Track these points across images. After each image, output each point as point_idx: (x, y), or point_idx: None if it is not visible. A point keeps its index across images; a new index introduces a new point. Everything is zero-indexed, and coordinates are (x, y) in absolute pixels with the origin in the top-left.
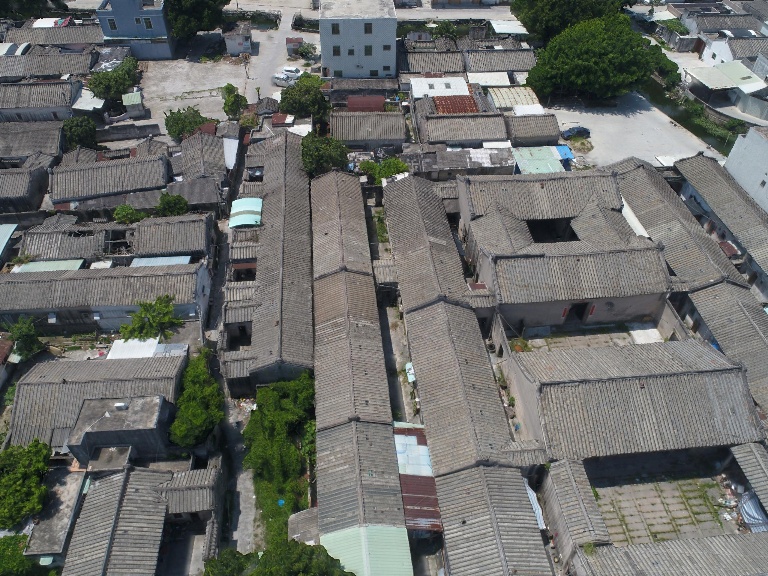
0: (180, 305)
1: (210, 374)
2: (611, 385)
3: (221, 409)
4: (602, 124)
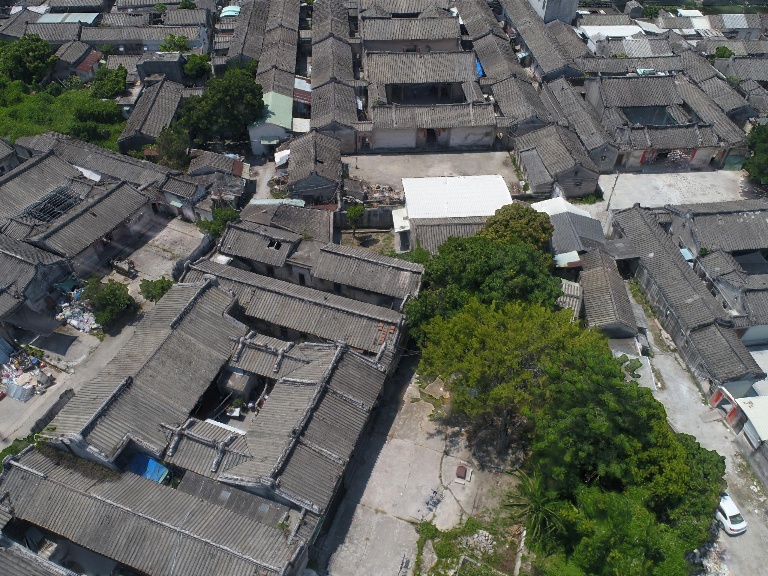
0: (191, 43)
1: None
2: (405, 56)
3: None
4: None
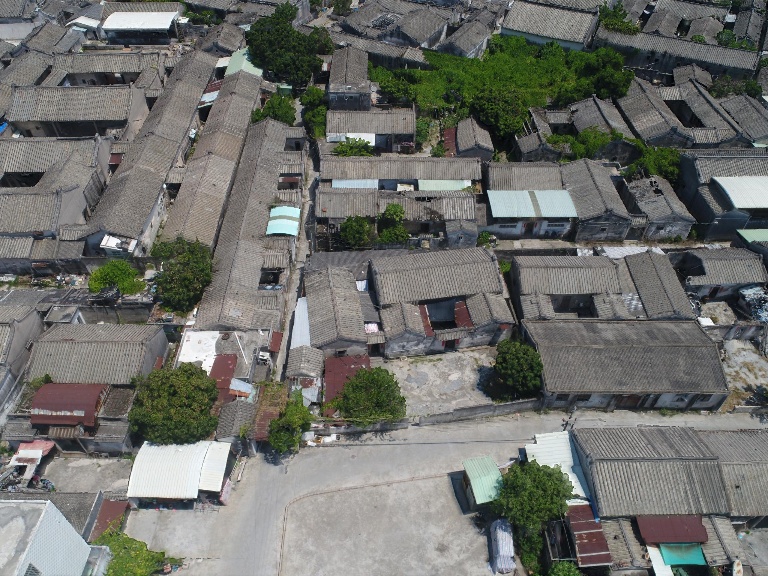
0: None
1: None
2: None
3: (311, 143)
4: None
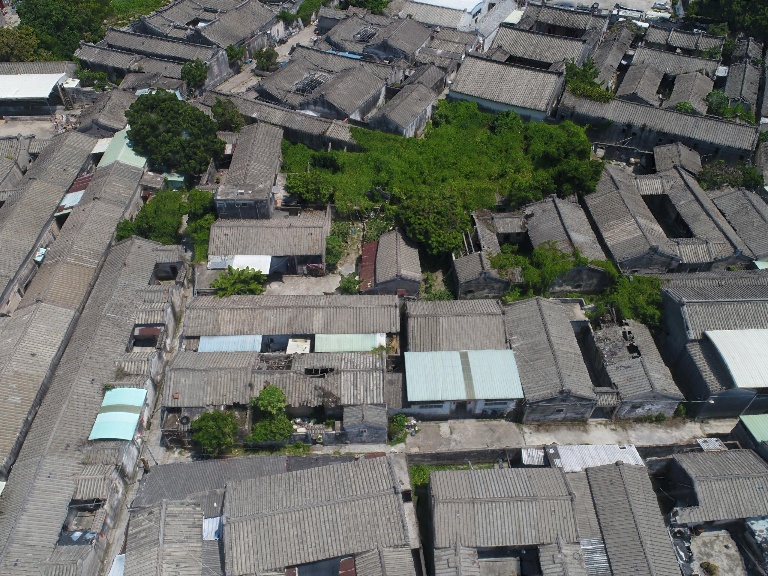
0: None
1: None
2: None
3: None
4: None
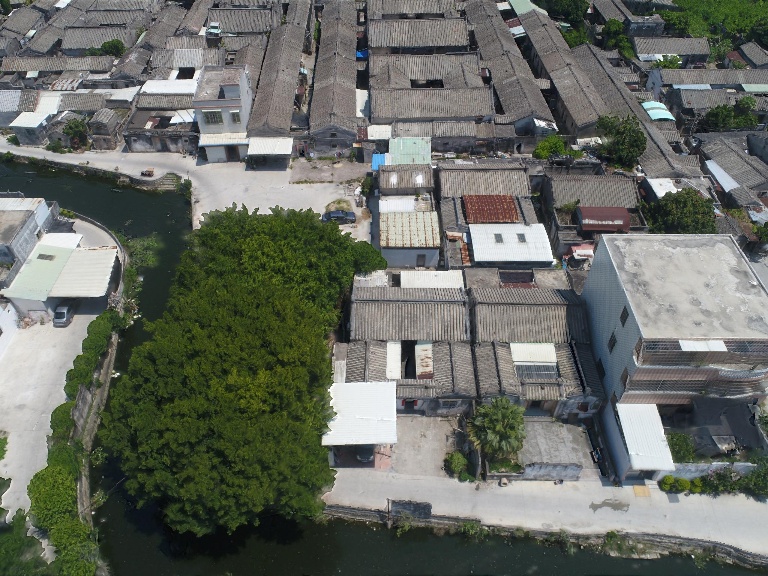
0: None
1: (621, 59)
2: None
3: None
4: None
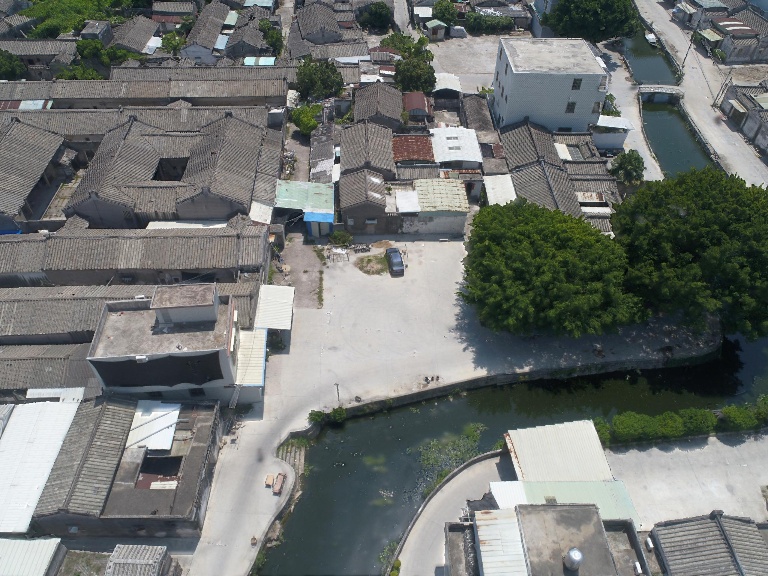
0: None
1: None
2: None
3: None
4: (428, 296)
